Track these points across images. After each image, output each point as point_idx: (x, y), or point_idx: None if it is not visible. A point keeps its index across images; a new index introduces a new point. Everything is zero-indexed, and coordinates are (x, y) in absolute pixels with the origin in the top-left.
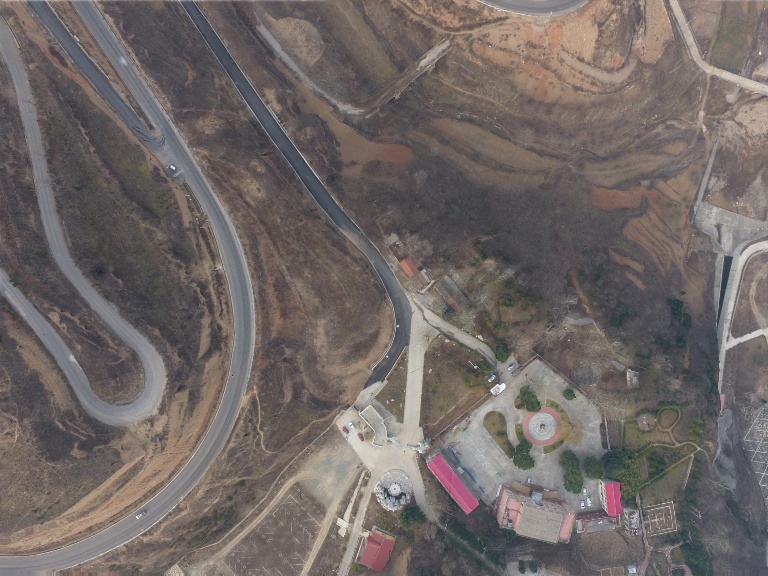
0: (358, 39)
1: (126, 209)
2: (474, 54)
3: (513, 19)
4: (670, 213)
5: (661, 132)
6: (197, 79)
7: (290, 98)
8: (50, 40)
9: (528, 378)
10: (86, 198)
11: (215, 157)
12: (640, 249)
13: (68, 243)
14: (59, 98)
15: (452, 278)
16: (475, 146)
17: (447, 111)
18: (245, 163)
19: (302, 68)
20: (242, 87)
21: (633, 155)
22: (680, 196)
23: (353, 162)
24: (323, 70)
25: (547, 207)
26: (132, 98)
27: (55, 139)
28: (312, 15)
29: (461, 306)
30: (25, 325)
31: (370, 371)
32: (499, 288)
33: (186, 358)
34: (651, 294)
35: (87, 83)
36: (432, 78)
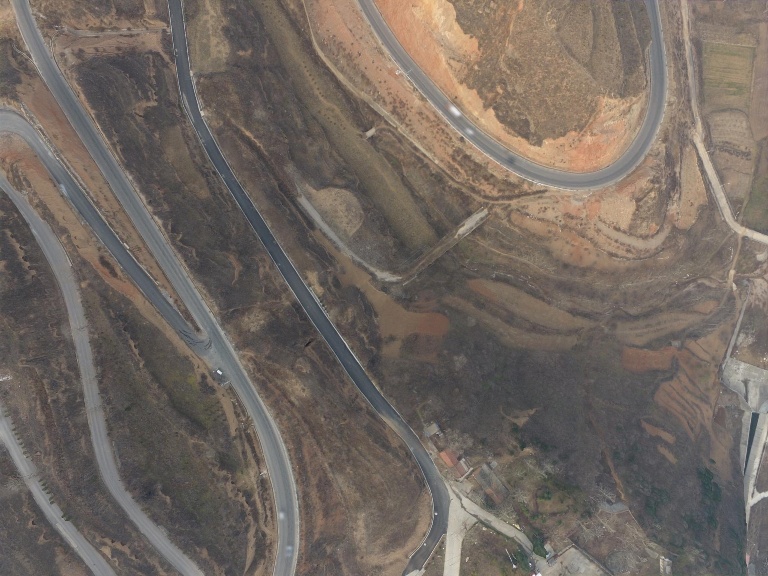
0: (396, 201)
1: (175, 426)
2: (512, 223)
3: (552, 192)
4: (699, 373)
5: (692, 291)
6: (243, 276)
7: (331, 274)
8: (100, 247)
9: (563, 566)
10: (135, 415)
11: (261, 358)
12: (671, 416)
13: (118, 464)
14: (110, 315)
15: (490, 466)
16: (509, 306)
17: (482, 270)
18: (290, 363)
19: (342, 238)
20: (284, 269)
21: (664, 314)
22: (709, 355)
23: (392, 337)
24: (362, 239)
25: (580, 372)
26: (179, 300)
27: (106, 357)
28: (352, 182)
29: (499, 496)
30: (76, 556)
31: (408, 559)
32: (537, 480)
33: (233, 575)
34: (682, 467)
35: (136, 289)
36: (468, 239)
